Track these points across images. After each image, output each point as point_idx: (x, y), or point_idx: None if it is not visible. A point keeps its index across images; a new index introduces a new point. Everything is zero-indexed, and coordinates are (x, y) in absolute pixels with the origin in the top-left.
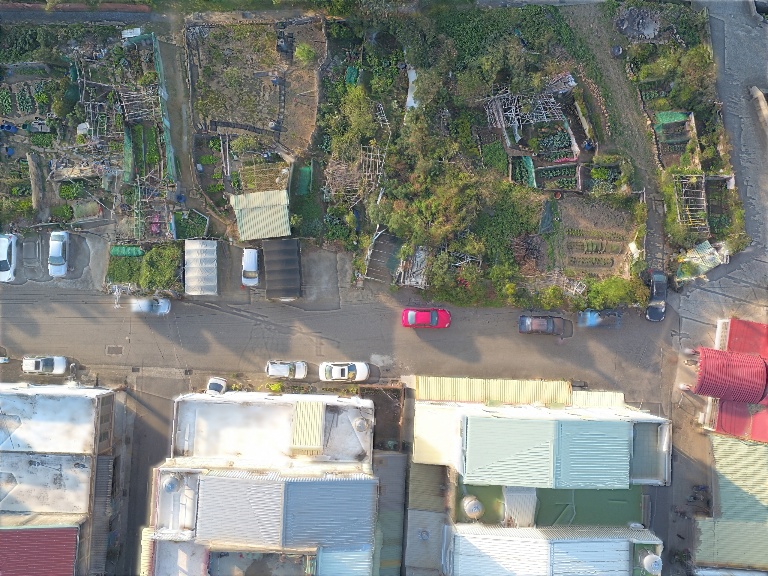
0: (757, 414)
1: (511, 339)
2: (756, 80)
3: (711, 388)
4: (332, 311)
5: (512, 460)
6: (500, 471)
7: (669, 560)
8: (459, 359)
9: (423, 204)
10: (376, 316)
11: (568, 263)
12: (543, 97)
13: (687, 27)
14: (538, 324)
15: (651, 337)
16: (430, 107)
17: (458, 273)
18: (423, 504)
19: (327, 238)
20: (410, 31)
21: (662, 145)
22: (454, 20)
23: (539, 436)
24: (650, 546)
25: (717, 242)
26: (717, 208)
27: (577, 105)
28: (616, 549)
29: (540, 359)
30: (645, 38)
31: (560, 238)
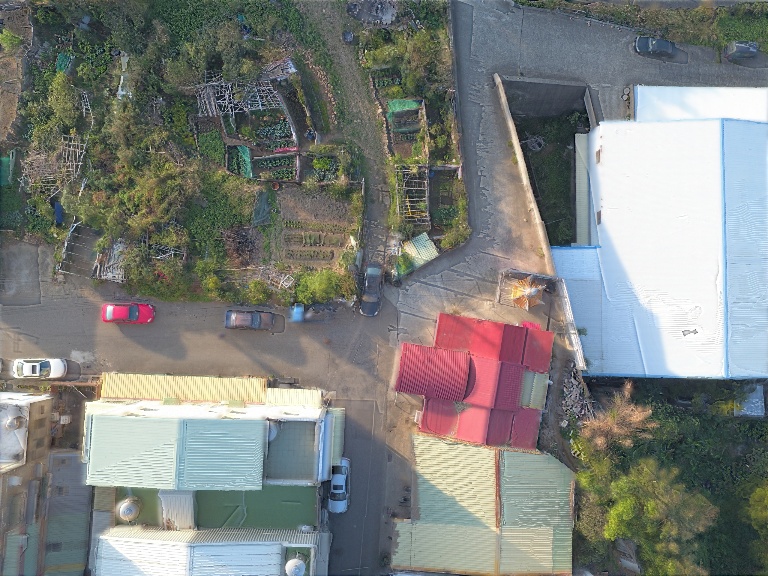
0: (463, 412)
1: (219, 335)
2: (505, 67)
3: (411, 385)
4: (32, 306)
5: (136, 460)
6: (124, 472)
7: (379, 563)
8: (164, 355)
9: (125, 195)
10: (78, 311)
11: (285, 256)
12: (260, 84)
13: (429, 12)
14: (242, 319)
15: (367, 332)
16: (141, 95)
17: (158, 266)
18: (108, 505)
19: (28, 230)
20: (114, 16)
21: (394, 134)
22: (172, 5)
23: (164, 435)
24: (304, 549)
25: (444, 234)
26: (447, 199)
27: (298, 93)
28: (266, 552)
29: (249, 355)
30: (382, 24)
31: (278, 230)
